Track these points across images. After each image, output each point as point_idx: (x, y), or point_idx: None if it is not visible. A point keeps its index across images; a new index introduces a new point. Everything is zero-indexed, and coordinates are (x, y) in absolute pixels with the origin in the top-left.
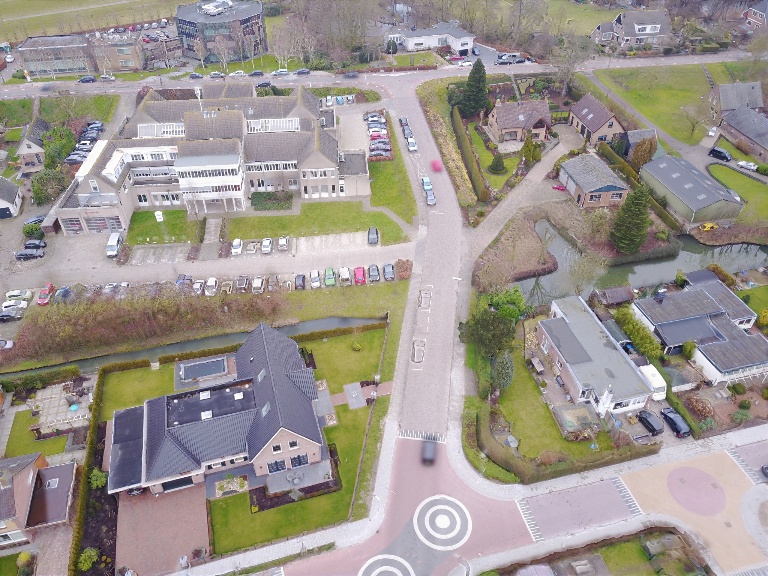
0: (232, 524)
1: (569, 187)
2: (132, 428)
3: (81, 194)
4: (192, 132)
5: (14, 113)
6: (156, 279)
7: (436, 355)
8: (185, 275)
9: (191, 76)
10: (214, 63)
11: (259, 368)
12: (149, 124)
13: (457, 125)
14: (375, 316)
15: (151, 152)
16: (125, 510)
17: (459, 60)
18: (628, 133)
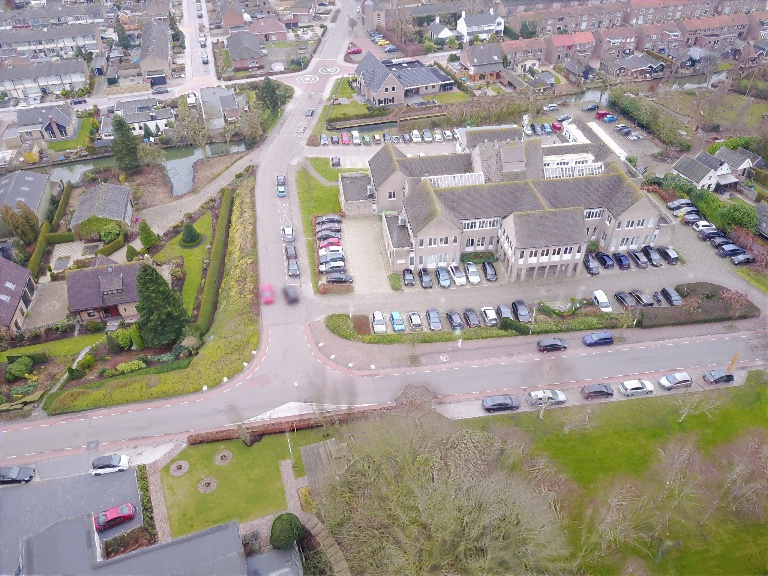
0: None
1: None
2: (441, 77)
3: None
4: None
5: None
6: None
7: (300, 112)
8: None
9: None
10: None
11: None
12: (590, 163)
13: None
14: None
15: None
16: None
17: None
18: (1, 247)
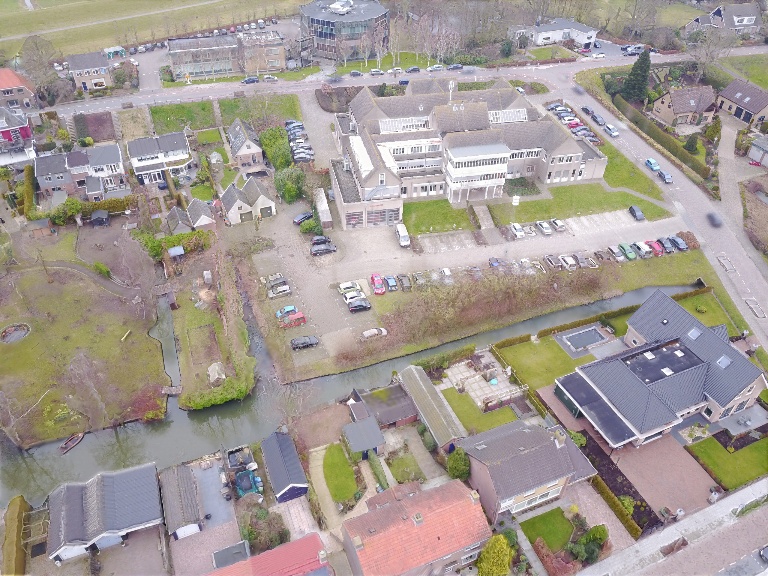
0: (722, 464)
1: (765, 162)
2: (585, 391)
3: (367, 188)
4: (444, 125)
5: (195, 116)
6: (464, 264)
7: None
8: (495, 258)
9: (352, 74)
10: (346, 61)
11: (686, 328)
12: (390, 119)
13: (629, 112)
14: (686, 283)
15: (413, 145)
16: (620, 462)
17: (588, 53)
18: None
